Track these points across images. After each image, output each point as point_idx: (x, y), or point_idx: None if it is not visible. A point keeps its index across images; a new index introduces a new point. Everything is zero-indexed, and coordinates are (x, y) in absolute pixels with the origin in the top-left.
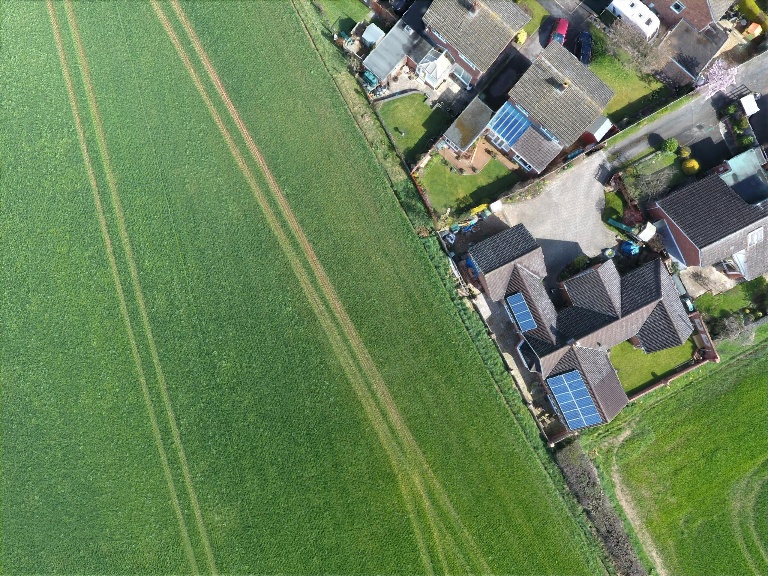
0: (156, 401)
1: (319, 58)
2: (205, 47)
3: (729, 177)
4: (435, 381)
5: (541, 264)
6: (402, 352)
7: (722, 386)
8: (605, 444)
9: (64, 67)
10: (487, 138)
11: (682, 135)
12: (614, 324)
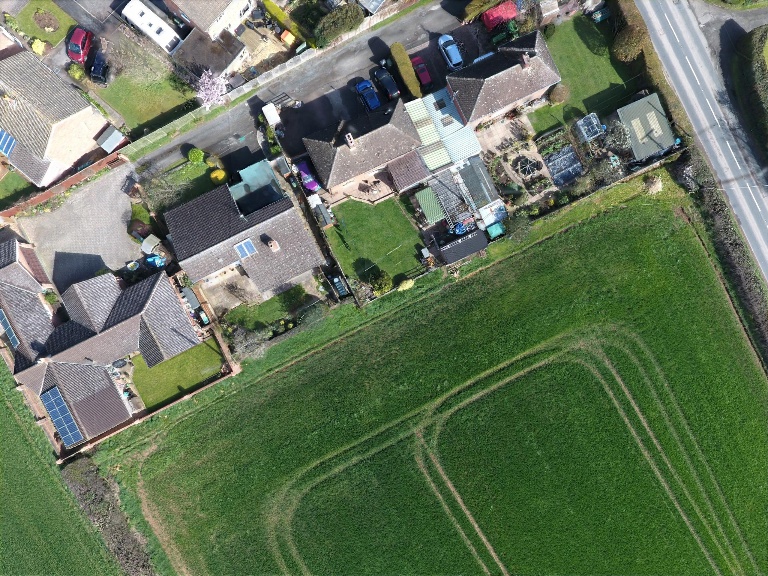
0: None
1: None
2: None
3: (240, 188)
4: None
5: (27, 279)
6: None
7: (258, 399)
8: (129, 459)
9: None
10: None
11: (218, 145)
12: (93, 339)
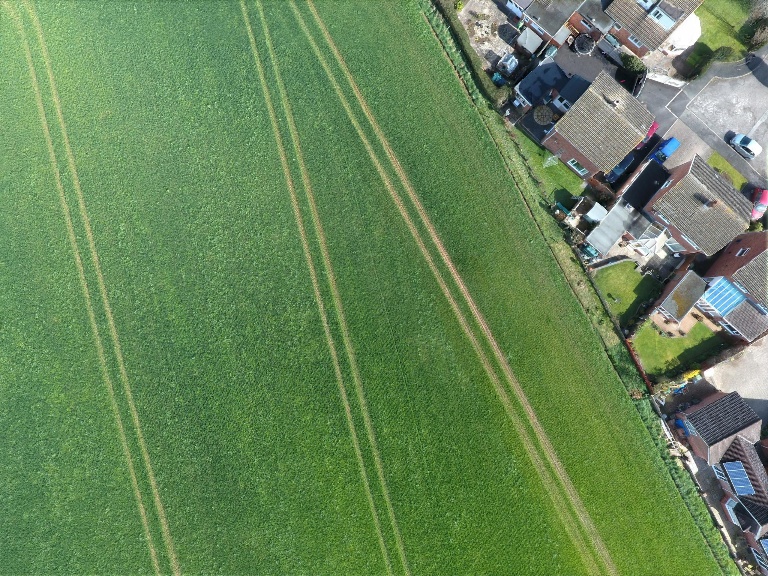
0: (395, 562)
1: (537, 228)
2: (433, 220)
3: None
4: (648, 537)
5: (757, 432)
6: (617, 509)
7: None
8: None
9: (304, 242)
10: None
11: None
12: None
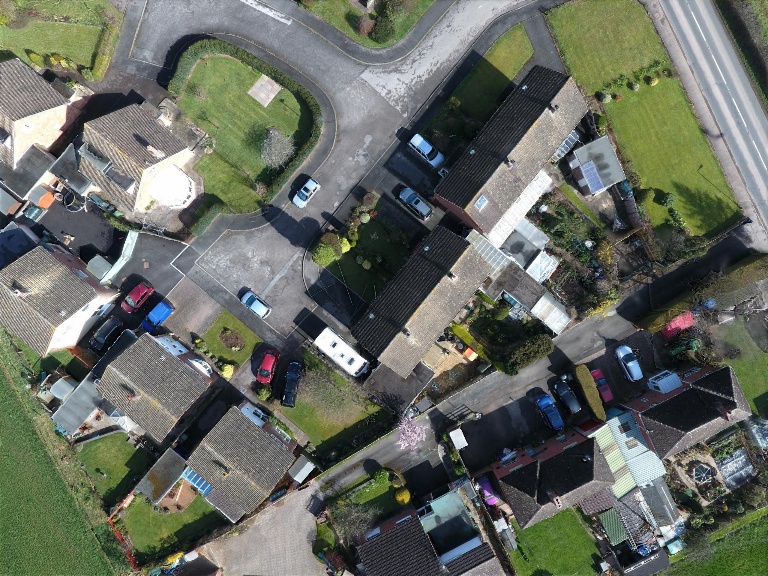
0: None
1: (19, 399)
2: None
3: (431, 519)
4: None
5: None
6: None
7: None
8: None
9: None
10: None
11: (399, 459)
12: None
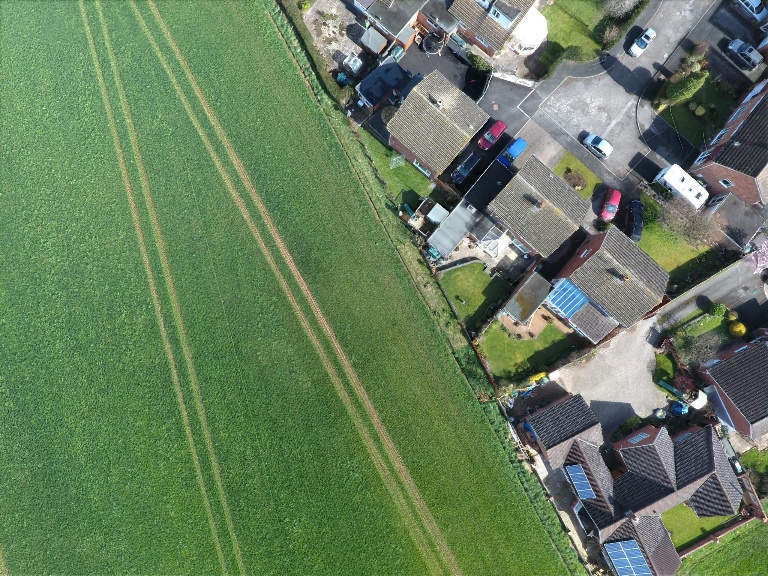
0: (231, 568)
1: (383, 230)
2: (275, 222)
3: None
4: (495, 541)
5: (599, 435)
6: (464, 513)
7: (767, 538)
8: None
9: (142, 245)
10: (544, 304)
11: (728, 296)
12: (670, 496)
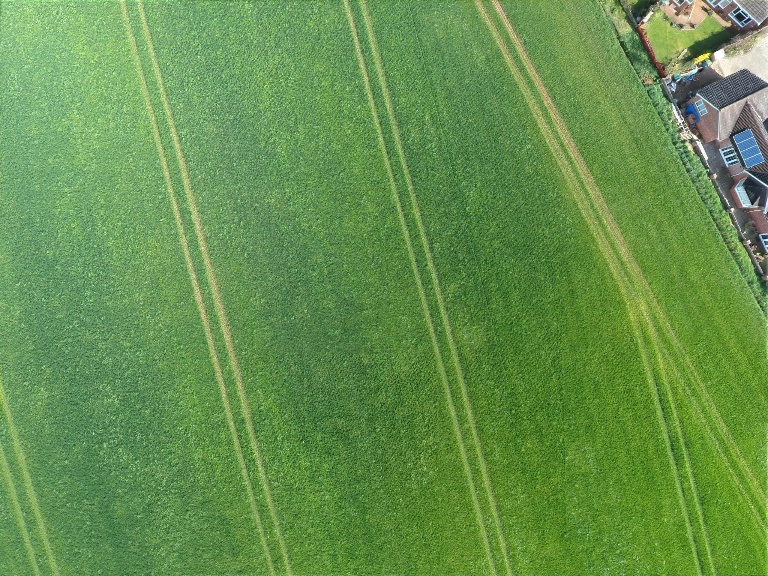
0: (412, 226)
1: None
2: None
3: None
4: (659, 218)
5: (766, 104)
6: (629, 190)
7: None
8: None
9: None
10: None
11: None
12: None
